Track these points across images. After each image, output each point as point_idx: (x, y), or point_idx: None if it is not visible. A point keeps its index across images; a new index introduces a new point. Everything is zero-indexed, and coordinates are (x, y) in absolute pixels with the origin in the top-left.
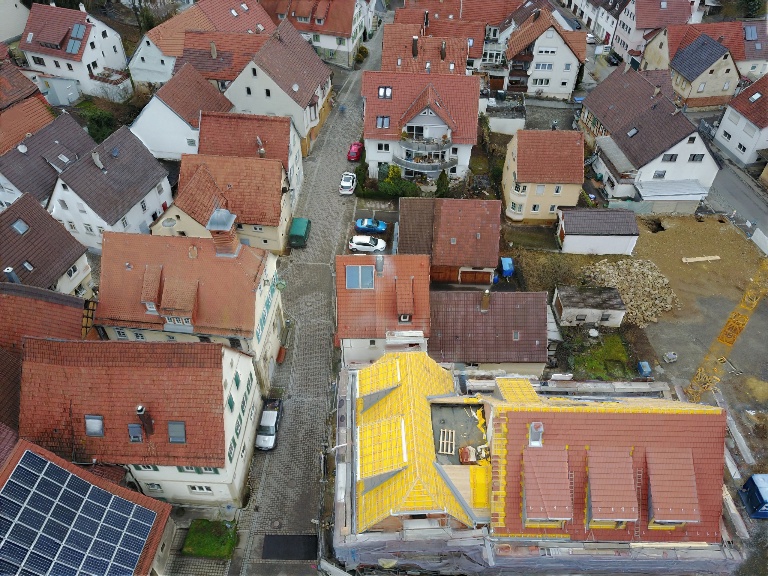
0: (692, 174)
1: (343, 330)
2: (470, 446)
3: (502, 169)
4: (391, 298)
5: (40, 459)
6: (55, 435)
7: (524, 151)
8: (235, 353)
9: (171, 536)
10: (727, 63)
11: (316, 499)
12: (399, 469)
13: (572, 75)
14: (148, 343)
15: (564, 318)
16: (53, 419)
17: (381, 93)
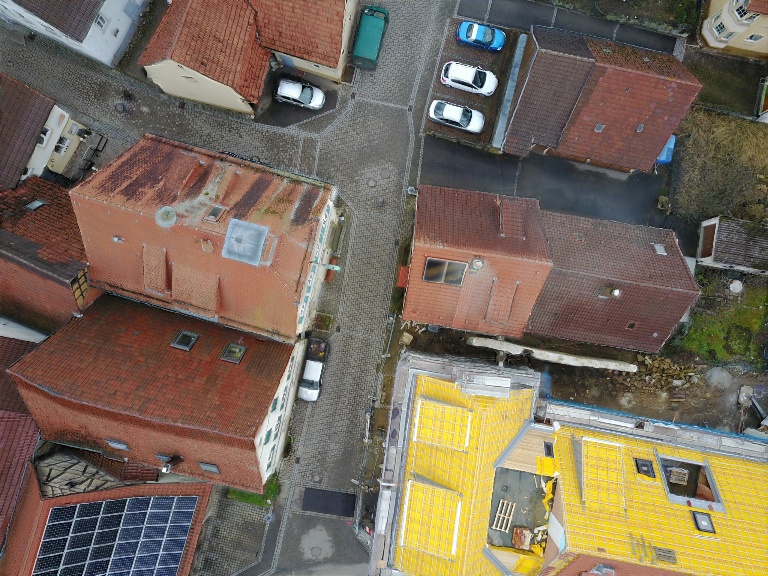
0: None
1: (410, 314)
2: (527, 531)
3: None
4: (482, 296)
5: (68, 508)
6: (78, 435)
7: None
8: None
9: (215, 485)
10: None
11: (358, 458)
12: (445, 559)
13: None
14: (162, 423)
15: None
16: (71, 427)
17: None
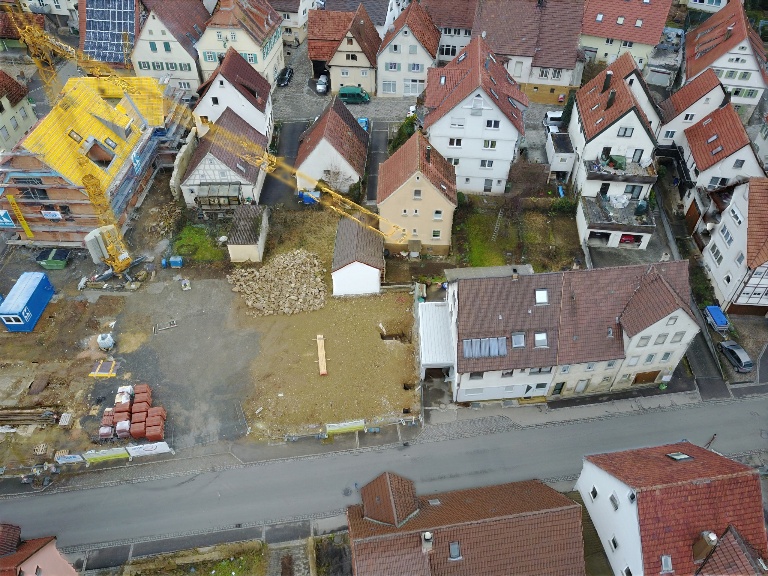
0: None
1: None
2: None
3: (490, 219)
4: None
5: (134, 7)
6: None
7: None
8: (168, 31)
9: None
10: None
11: None
12: None
13: (738, 276)
14: None
15: None
16: None
17: None
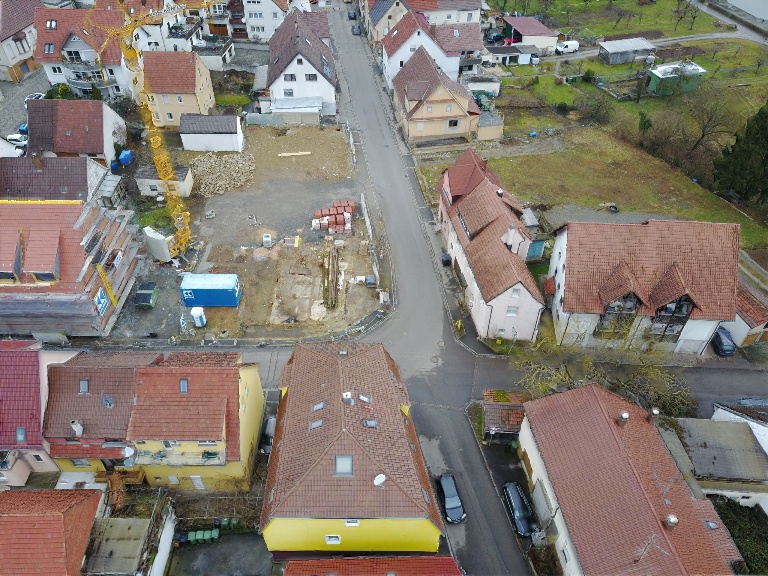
0: (315, 92)
1: None
2: None
3: None
4: None
5: None
6: None
7: (149, 68)
8: None
9: None
10: (401, 10)
11: None
12: None
13: None
14: None
15: (141, 188)
16: None
17: (48, 25)
